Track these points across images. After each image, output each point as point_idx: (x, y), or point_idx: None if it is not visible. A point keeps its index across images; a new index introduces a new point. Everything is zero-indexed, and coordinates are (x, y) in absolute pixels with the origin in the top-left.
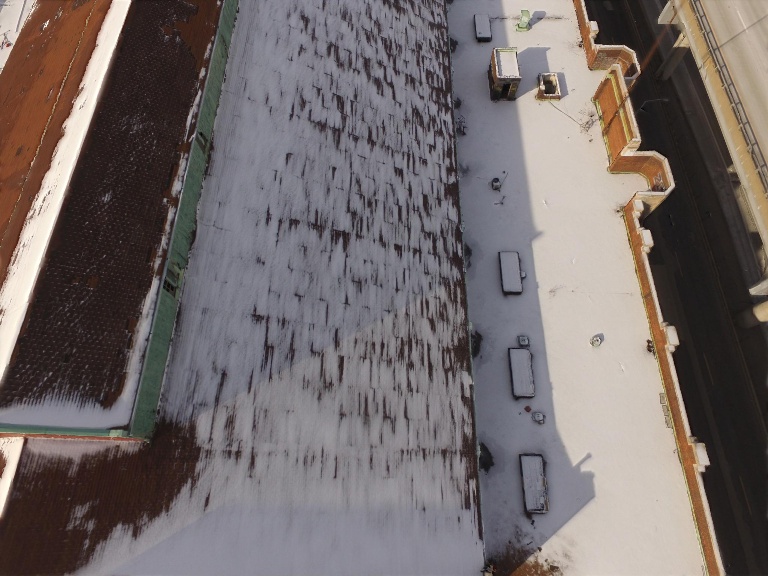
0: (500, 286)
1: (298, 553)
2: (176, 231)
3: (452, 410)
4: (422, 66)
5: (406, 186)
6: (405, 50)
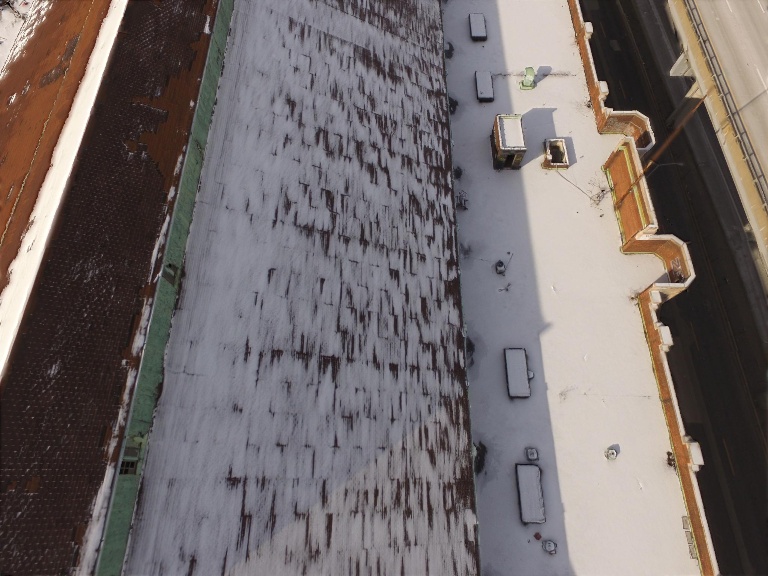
0: (506, 389)
1: None
2: (137, 397)
3: (455, 561)
4: (420, 143)
5: (402, 290)
6: (401, 127)
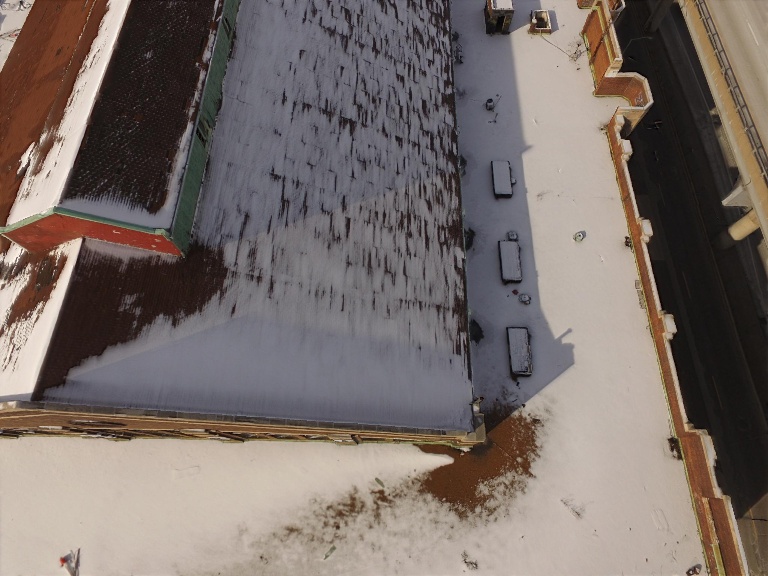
0: (492, 190)
1: (310, 362)
2: (206, 91)
3: (446, 275)
4: None
5: (407, 91)
6: None
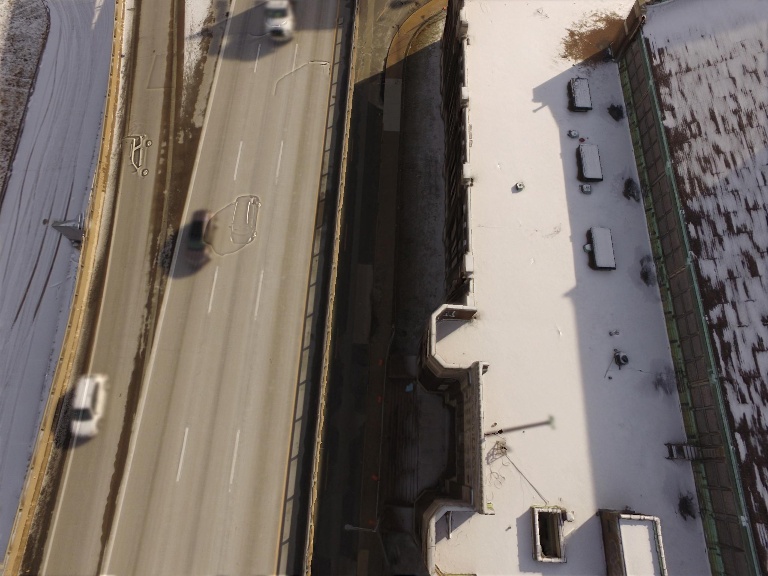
0: None
1: None
2: None
3: (684, 97)
4: None
5: None
6: None
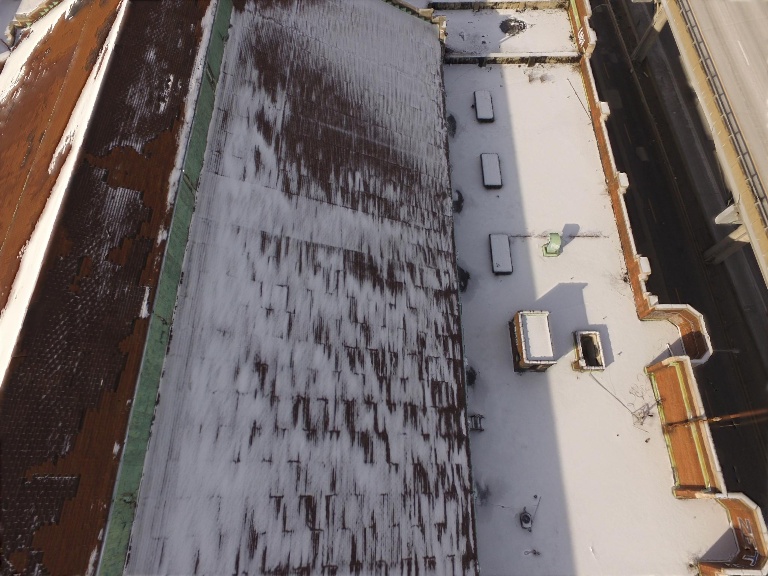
0: None
1: None
2: None
3: None
4: (426, 377)
5: None
6: (403, 359)
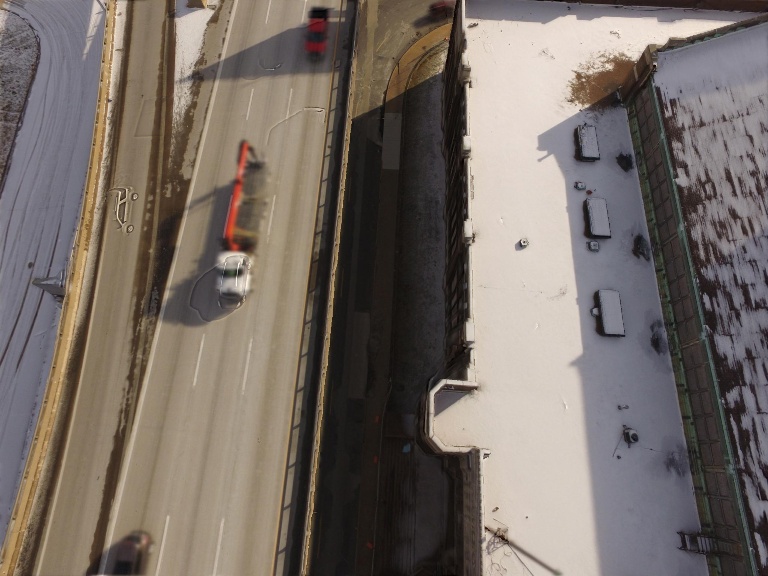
0: None
1: None
2: None
3: (698, 154)
4: None
5: None
6: None
